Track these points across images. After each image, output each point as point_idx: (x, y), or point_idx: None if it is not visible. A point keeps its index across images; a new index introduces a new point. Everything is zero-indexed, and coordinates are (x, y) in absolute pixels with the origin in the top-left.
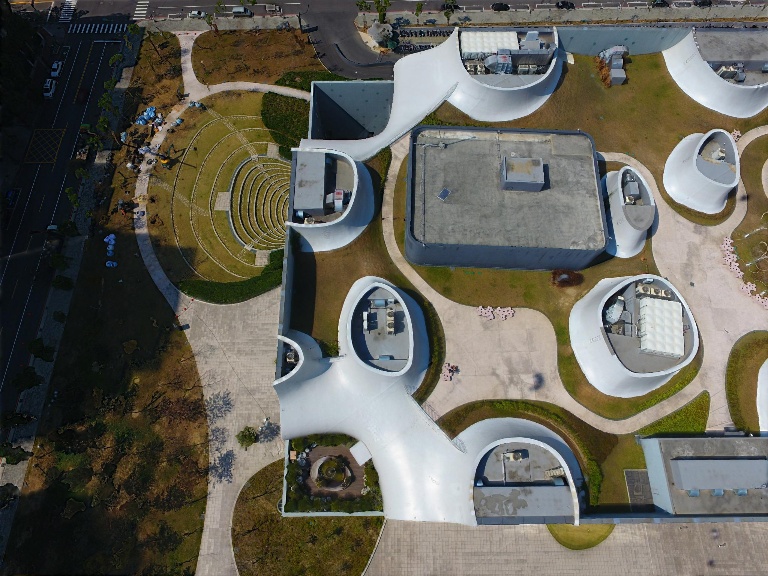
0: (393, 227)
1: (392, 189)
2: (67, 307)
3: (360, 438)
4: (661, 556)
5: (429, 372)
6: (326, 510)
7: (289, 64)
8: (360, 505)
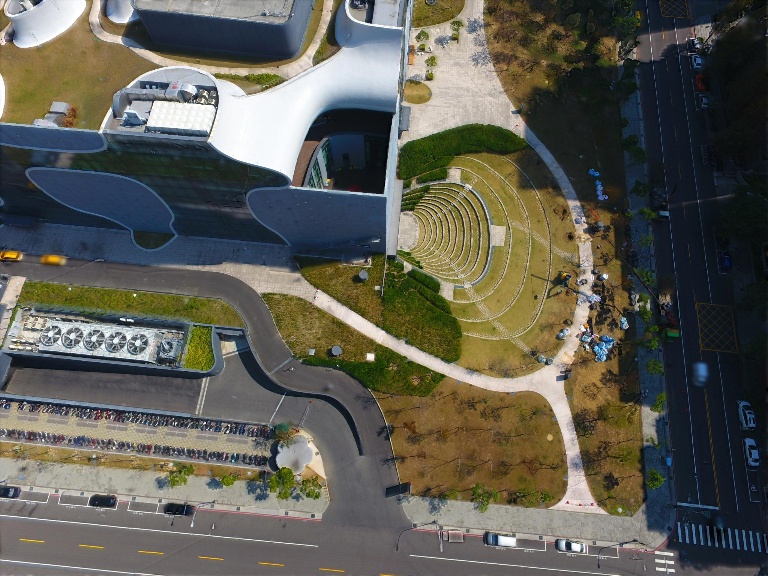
0: (324, 4)
1: (319, 32)
2: None
3: None
4: None
5: None
6: None
7: (428, 415)
8: None
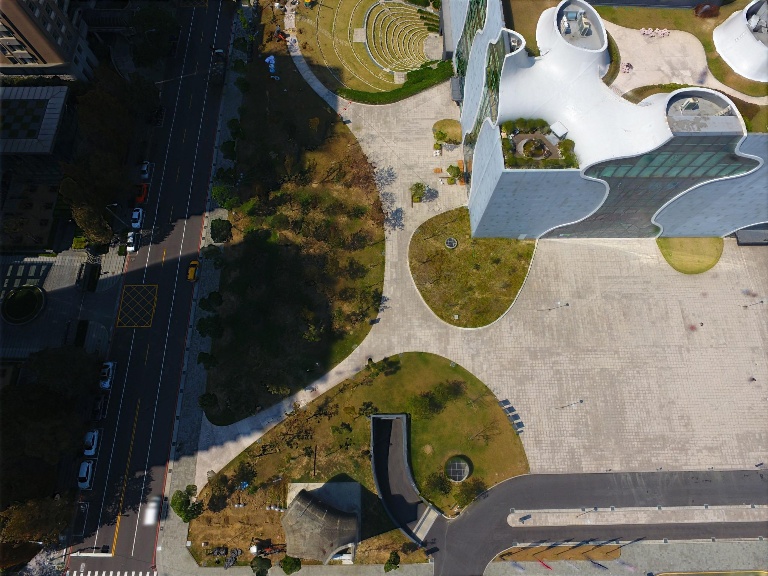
0: None
1: None
2: (238, 114)
3: (557, 119)
4: (758, 278)
5: (611, 66)
6: (536, 168)
7: None
8: (564, 160)
